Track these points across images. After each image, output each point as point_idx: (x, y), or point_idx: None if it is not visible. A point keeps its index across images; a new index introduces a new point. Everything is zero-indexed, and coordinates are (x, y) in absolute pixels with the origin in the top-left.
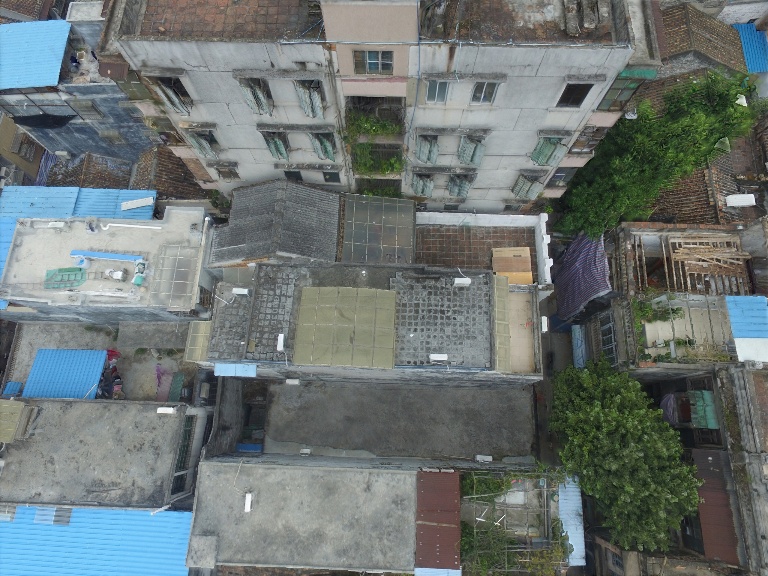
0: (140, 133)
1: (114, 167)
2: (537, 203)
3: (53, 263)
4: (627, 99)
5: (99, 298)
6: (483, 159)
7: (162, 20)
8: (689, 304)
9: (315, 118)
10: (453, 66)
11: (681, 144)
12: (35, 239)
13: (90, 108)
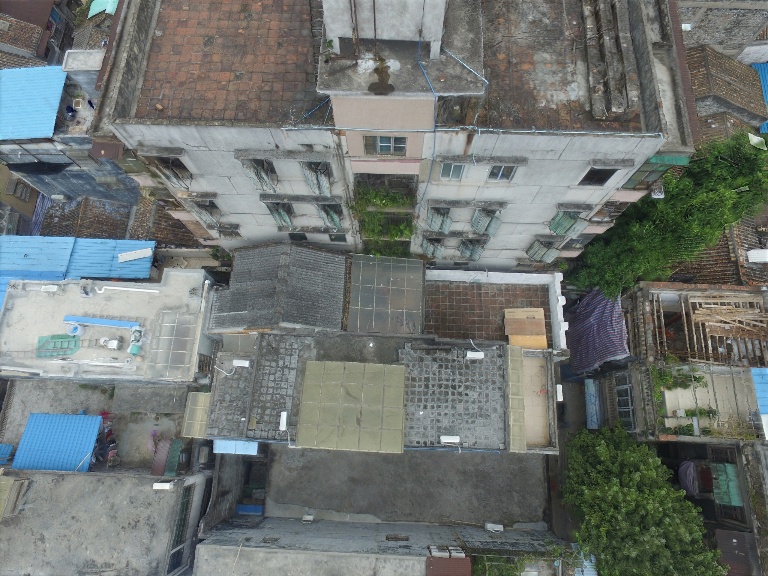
0: None
1: (112, 210)
2: None
3: (45, 329)
4: (655, 180)
5: (93, 368)
6: None
7: (160, 96)
8: None
9: None
10: (470, 150)
11: (708, 217)
12: (27, 302)
13: (87, 157)
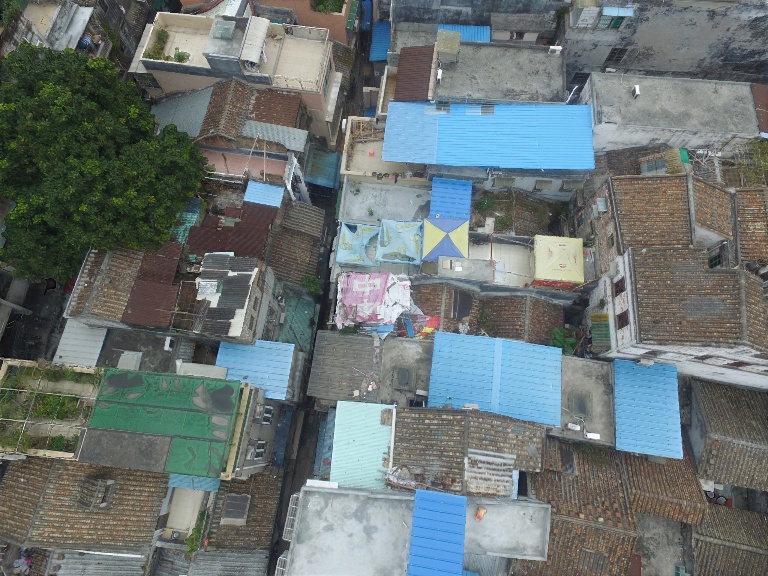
0: None
1: None
2: None
3: None
4: None
5: None
6: None
7: None
8: None
9: None
10: None
11: None
12: None
13: None
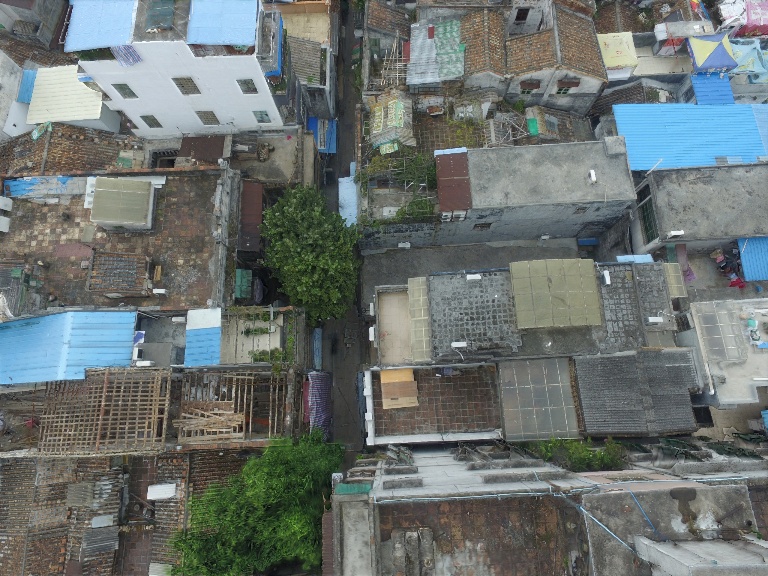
0: None
1: None
2: None
3: None
4: None
5: None
6: None
7: None
8: None
9: None
10: None
11: None
12: None
13: None
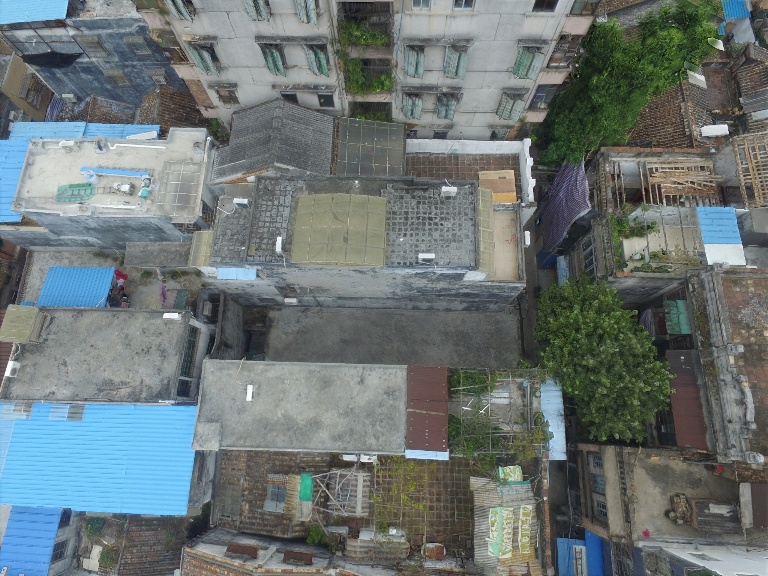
0: (143, 73)
1: (118, 110)
2: (521, 130)
3: (64, 180)
4: (597, 1)
5: (108, 210)
6: (468, 76)
7: None
8: (664, 221)
9: (309, 29)
10: None
11: (651, 54)
12: (46, 159)
13: (96, 44)
